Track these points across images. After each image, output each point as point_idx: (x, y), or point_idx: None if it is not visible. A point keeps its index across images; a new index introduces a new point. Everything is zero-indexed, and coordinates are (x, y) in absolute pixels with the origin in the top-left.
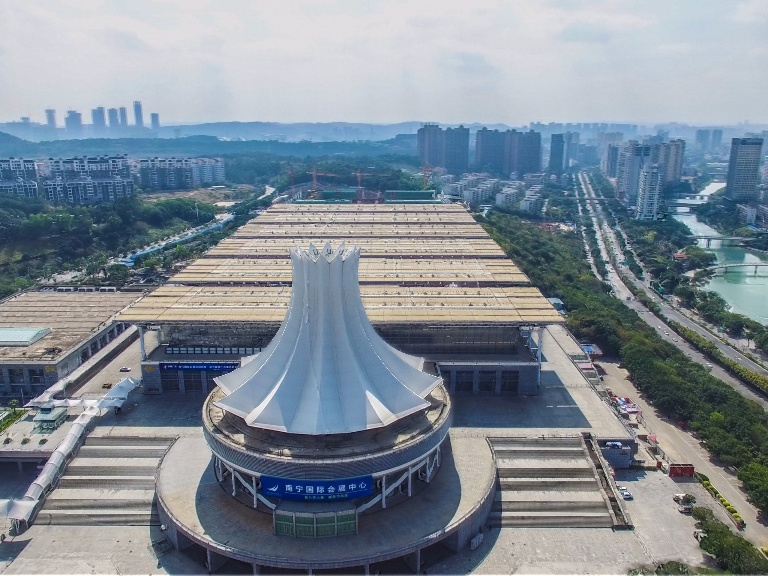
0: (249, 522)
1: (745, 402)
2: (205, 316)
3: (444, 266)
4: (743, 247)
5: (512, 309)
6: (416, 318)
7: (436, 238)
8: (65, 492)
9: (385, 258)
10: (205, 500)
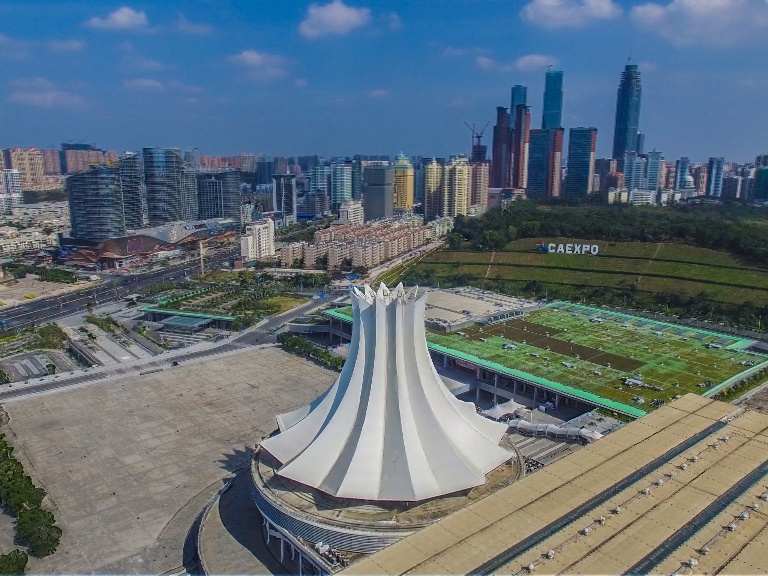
0: None
1: None
2: (653, 427)
3: None
4: None
5: None
6: (434, 536)
7: None
8: (517, 438)
9: None
10: None
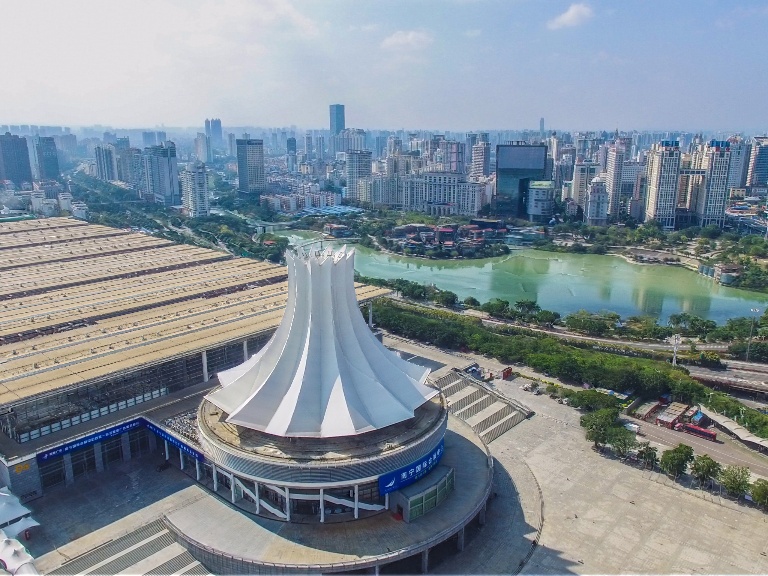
0: (375, 529)
1: (472, 325)
2: (79, 375)
3: (205, 273)
4: (290, 230)
5: None
6: None
7: (125, 252)
8: None
9: (121, 278)
10: (308, 539)
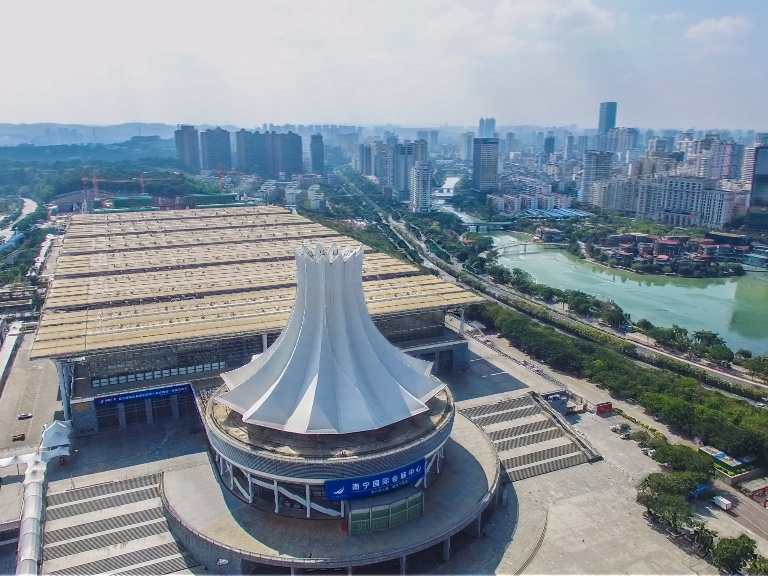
0: (315, 532)
1: (606, 350)
2: (142, 338)
3: None
4: (504, 230)
5: (434, 295)
6: None
7: (291, 239)
8: (59, 561)
9: (263, 262)
10: (251, 524)
